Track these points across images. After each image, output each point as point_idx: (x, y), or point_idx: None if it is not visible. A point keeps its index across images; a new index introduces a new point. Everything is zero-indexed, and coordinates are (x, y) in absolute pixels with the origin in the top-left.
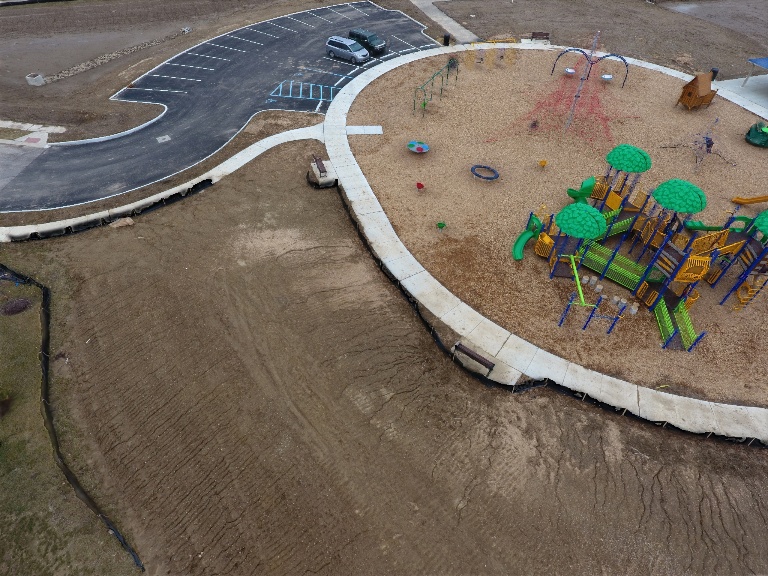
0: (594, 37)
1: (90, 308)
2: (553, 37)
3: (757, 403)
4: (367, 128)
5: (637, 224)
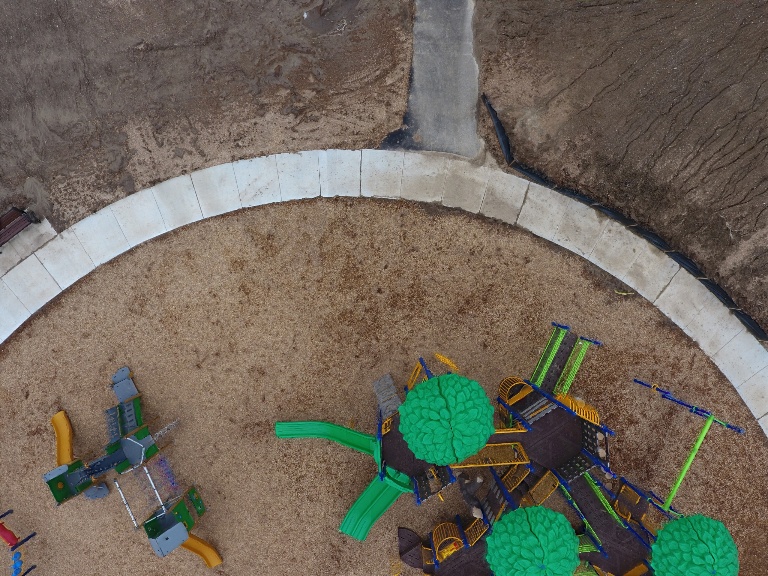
0: None
1: None
2: None
3: (535, 240)
4: None
5: (466, 553)
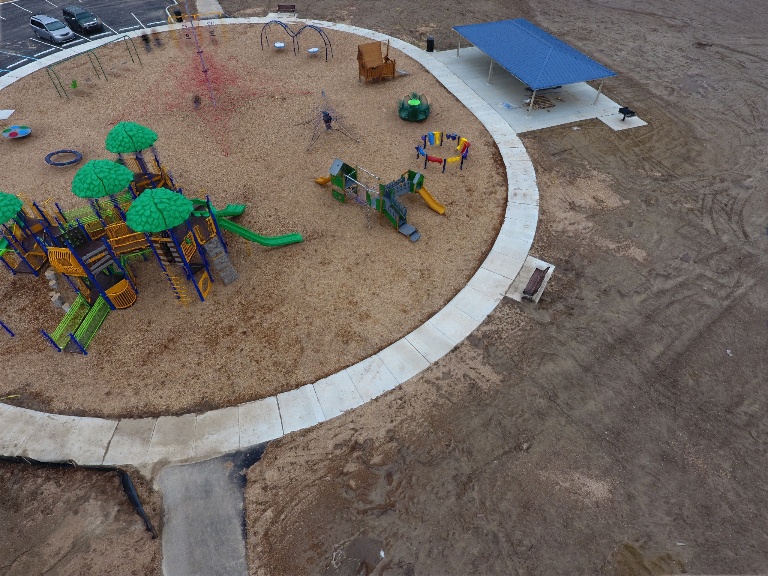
0: (349, 9)
1: None
2: (305, 10)
3: (99, 412)
4: None
5: None
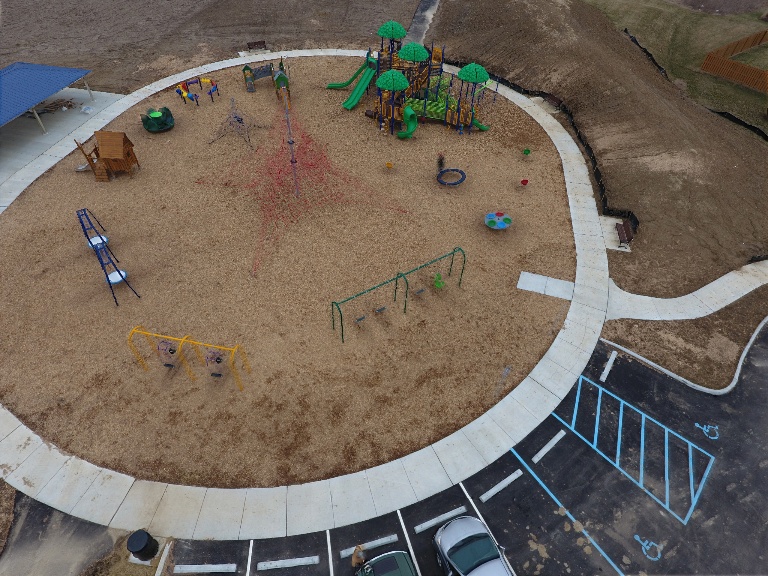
0: None
1: None
2: None
3: None
4: (541, 287)
5: None
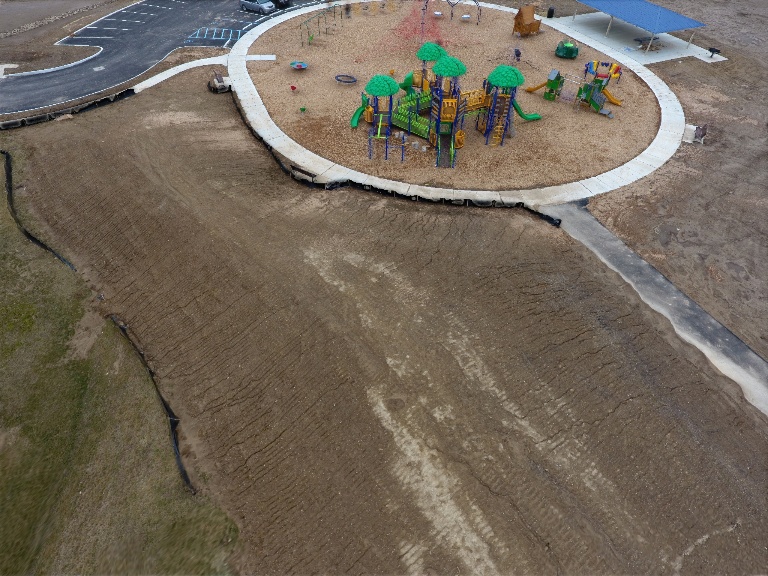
0: None
1: (40, 161)
2: None
3: (484, 189)
4: (263, 56)
5: None
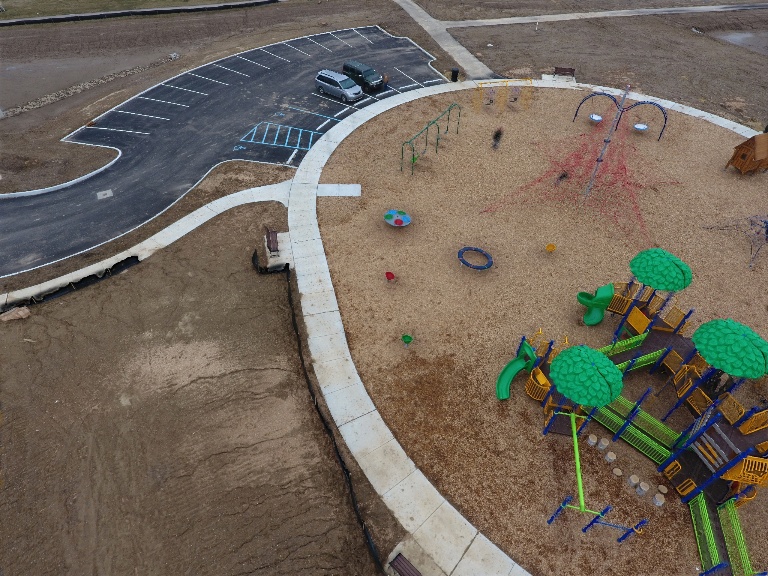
0: (628, 74)
1: None
2: (579, 73)
3: None
4: (343, 188)
5: None
